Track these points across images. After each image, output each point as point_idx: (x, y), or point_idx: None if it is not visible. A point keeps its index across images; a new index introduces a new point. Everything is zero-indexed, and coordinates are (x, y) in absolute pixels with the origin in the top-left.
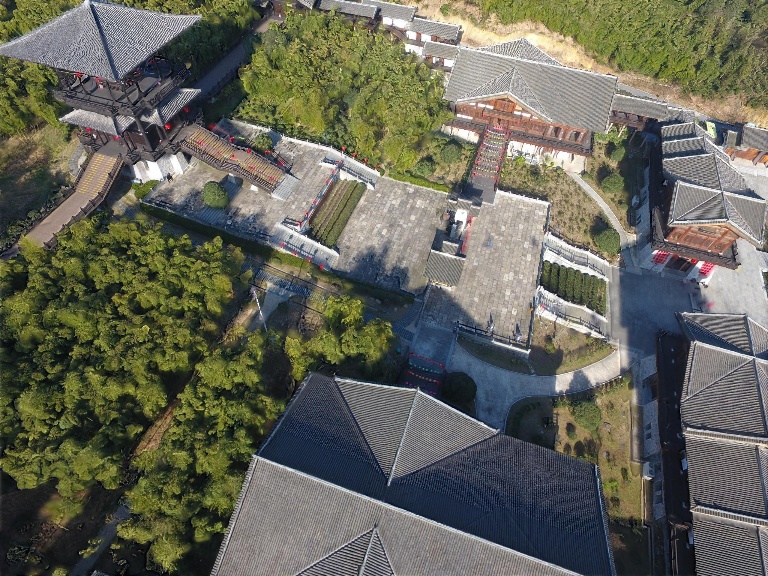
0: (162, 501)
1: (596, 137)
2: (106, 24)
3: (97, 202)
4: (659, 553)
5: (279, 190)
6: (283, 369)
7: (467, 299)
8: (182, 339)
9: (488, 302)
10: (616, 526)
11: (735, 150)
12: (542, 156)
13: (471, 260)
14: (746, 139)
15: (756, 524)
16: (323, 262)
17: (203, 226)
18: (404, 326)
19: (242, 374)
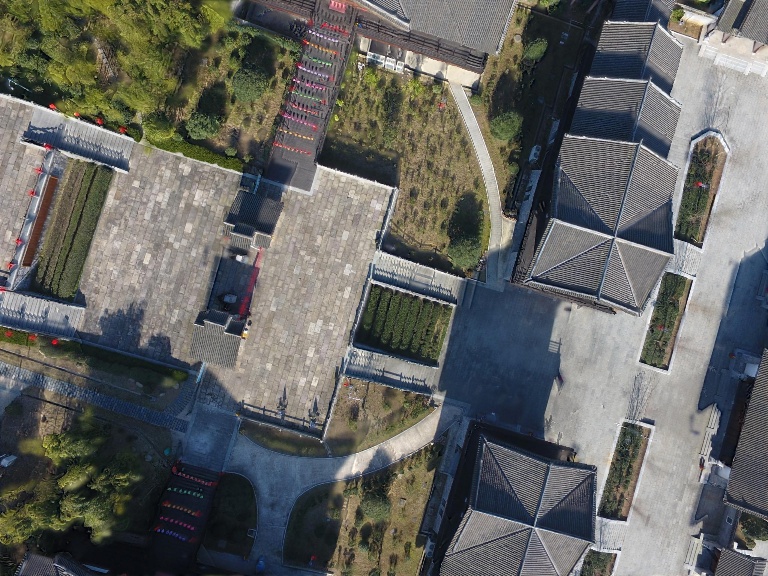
0: None
1: None
2: None
3: None
4: None
5: None
6: None
7: (257, 367)
8: None
9: (283, 370)
10: None
11: None
12: None
13: (267, 302)
14: (751, 21)
15: None
16: (62, 324)
17: None
18: (175, 414)
19: None
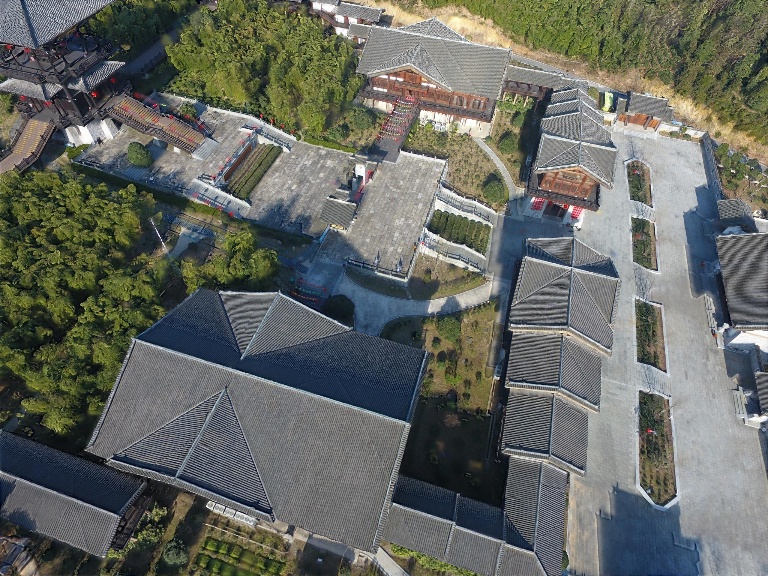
0: (61, 380)
1: (504, 107)
2: (29, 1)
3: (31, 161)
4: (497, 434)
5: (199, 151)
6: (188, 295)
7: (360, 240)
8: (89, 262)
9: (378, 242)
10: (464, 414)
11: (626, 116)
12: (452, 124)
13: (368, 209)
14: (632, 105)
15: (550, 391)
16: (235, 212)
17: (127, 181)
18: (300, 262)
19: (138, 288)
